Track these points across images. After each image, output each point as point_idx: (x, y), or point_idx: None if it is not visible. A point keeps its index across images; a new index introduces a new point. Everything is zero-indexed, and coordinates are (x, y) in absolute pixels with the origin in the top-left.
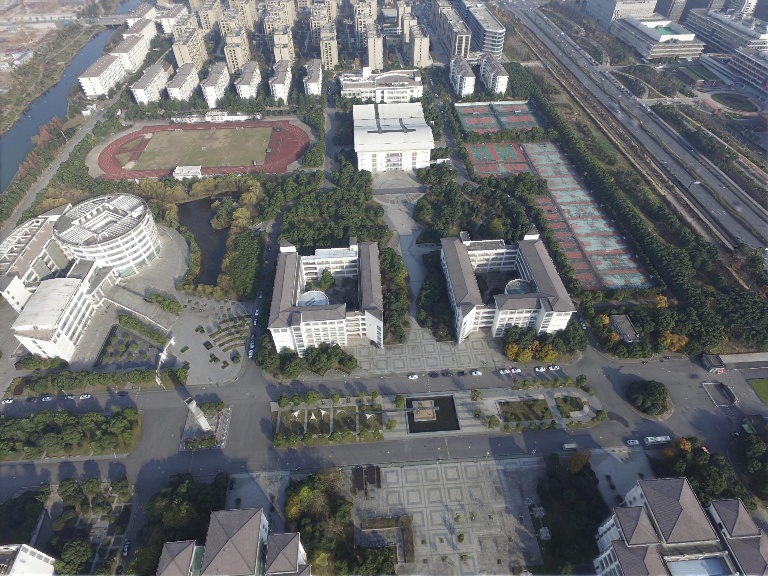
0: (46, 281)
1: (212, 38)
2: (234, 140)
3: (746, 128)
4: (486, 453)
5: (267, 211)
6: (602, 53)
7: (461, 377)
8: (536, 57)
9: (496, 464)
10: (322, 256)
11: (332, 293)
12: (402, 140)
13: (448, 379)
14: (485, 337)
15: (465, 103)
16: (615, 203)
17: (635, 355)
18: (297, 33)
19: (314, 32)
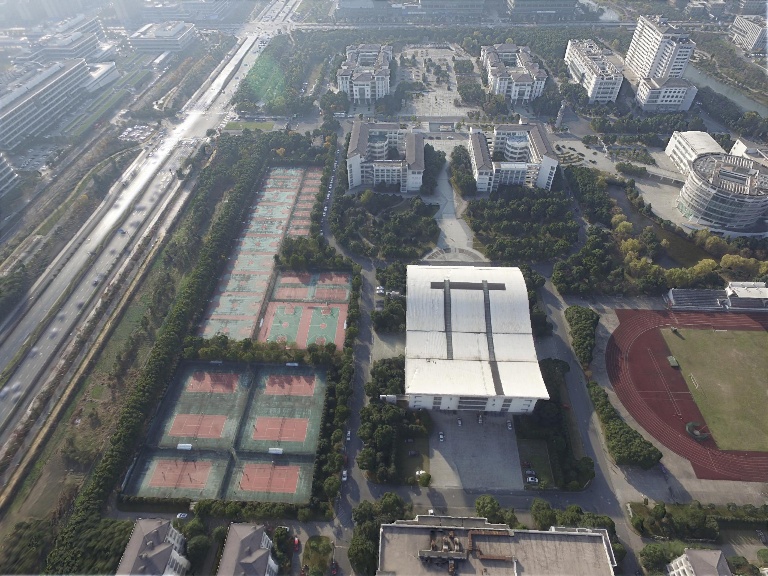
0: (723, 152)
1: None
2: (765, 404)
3: None
4: None
5: None
6: None
7: None
8: None
9: None
10: (521, 165)
11: None
12: (452, 270)
13: None
14: None
15: None
16: None
17: None
18: None
19: None
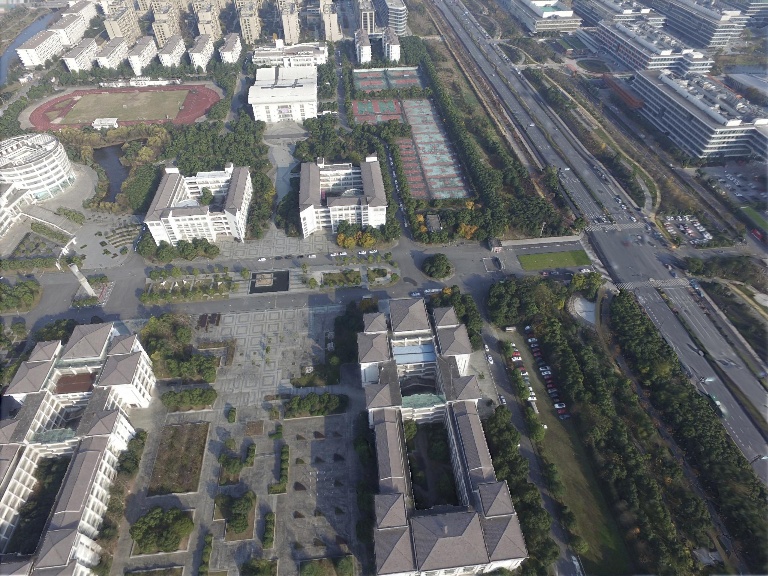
0: None
1: (148, 18)
2: (153, 100)
3: (594, 86)
4: (304, 304)
5: (168, 150)
6: (496, 29)
7: (299, 259)
8: (437, 32)
9: (309, 310)
10: (202, 177)
11: (212, 208)
12: (289, 94)
13: (289, 261)
14: (326, 234)
15: (363, 69)
16: (459, 140)
17: (433, 239)
18: (228, 14)
19: (239, 11)
